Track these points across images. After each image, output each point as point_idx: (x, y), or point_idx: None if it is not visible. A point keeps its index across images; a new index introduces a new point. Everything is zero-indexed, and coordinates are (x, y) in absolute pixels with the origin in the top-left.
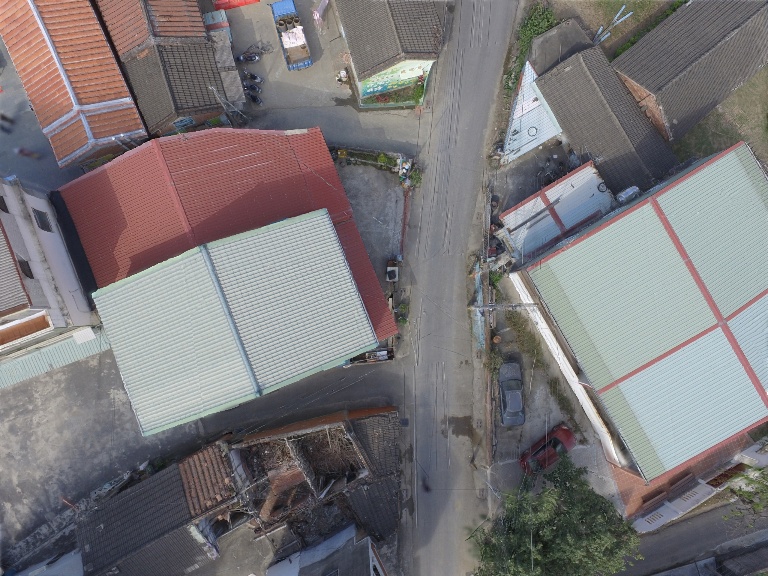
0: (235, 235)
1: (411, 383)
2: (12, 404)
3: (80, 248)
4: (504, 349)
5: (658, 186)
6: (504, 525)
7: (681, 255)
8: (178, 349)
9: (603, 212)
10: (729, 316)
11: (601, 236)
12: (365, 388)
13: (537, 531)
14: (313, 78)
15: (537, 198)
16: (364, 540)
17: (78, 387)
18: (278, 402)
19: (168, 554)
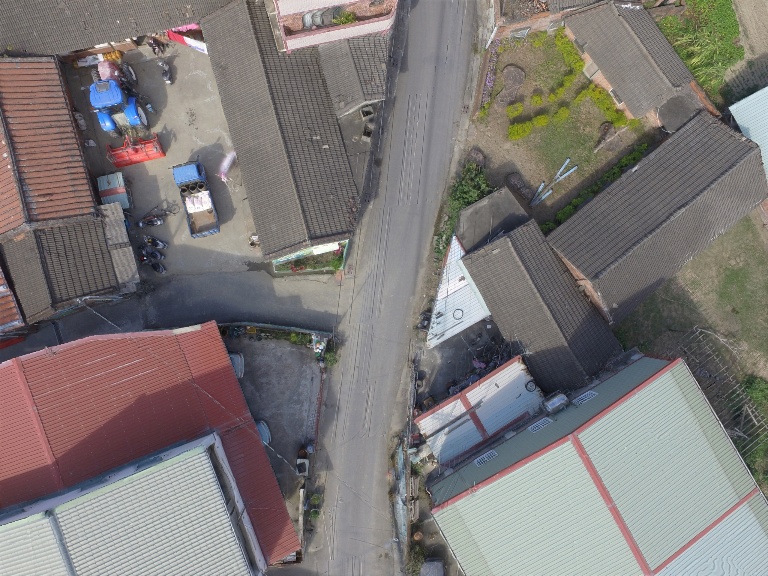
0: (91, 493)
1: None
2: None
3: None
4: (428, 541)
5: (589, 396)
6: None
7: (604, 500)
8: None
9: (531, 413)
10: (657, 567)
11: (515, 477)
12: None
13: None
14: (223, 240)
15: (457, 401)
16: None
17: None
18: None
19: None
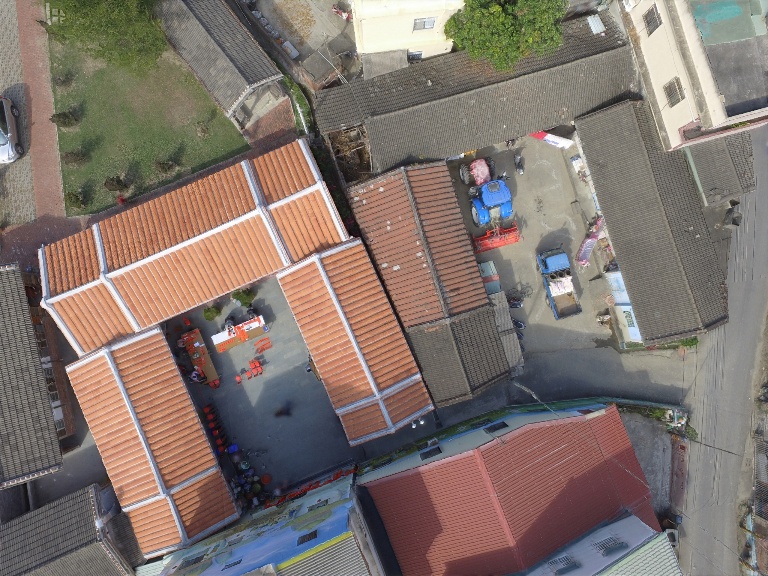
0: None
1: None
2: None
3: (388, 546)
4: None
5: None
6: None
7: None
8: None
9: None
10: None
11: None
12: None
13: None
14: (573, 319)
15: None
16: None
17: None
18: None
19: None
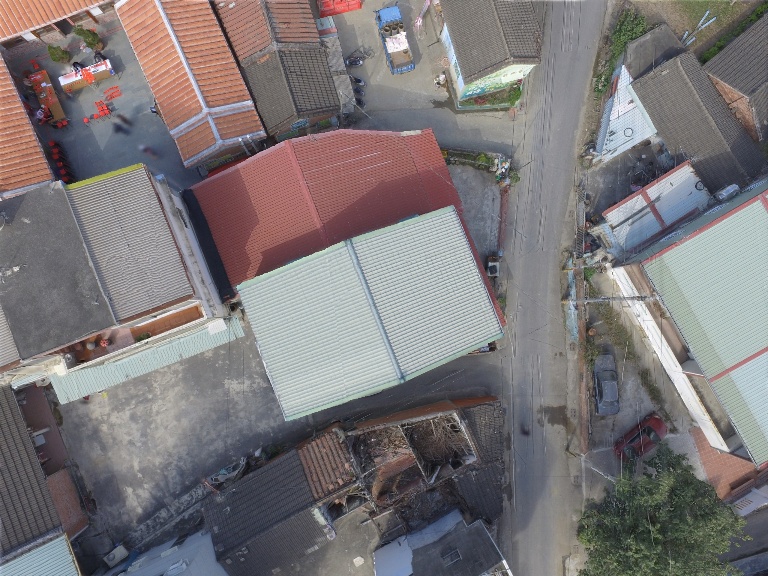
0: (375, 230)
1: (508, 374)
2: (133, 393)
3: (212, 244)
4: (597, 341)
5: (757, 184)
6: (617, 507)
7: None
8: (322, 338)
9: (700, 209)
10: None
11: (713, 232)
12: (465, 379)
13: (654, 512)
14: (412, 81)
15: (639, 196)
16: (476, 523)
17: (194, 377)
18: (387, 391)
19: (292, 535)
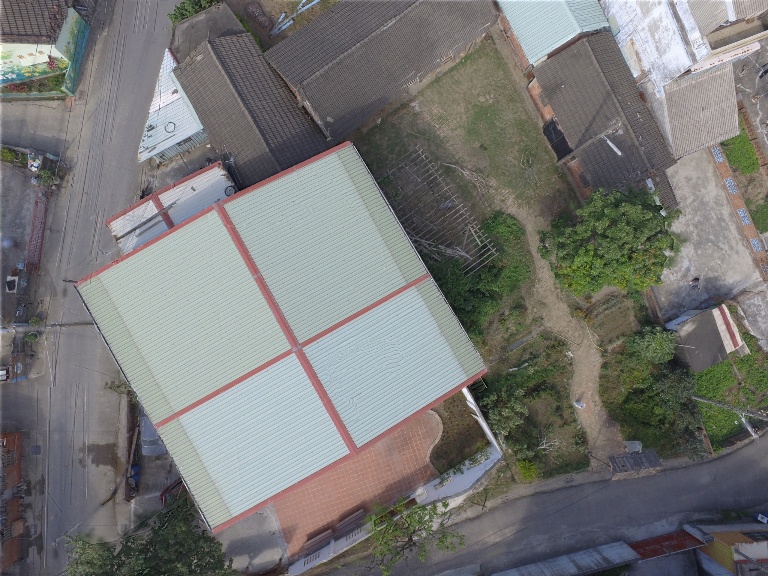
0: None
1: (45, 406)
2: None
3: None
4: None
5: None
6: None
7: (250, 270)
8: None
9: None
10: (306, 341)
11: (159, 247)
12: None
13: None
14: None
15: (149, 202)
16: None
17: None
18: None
19: None
